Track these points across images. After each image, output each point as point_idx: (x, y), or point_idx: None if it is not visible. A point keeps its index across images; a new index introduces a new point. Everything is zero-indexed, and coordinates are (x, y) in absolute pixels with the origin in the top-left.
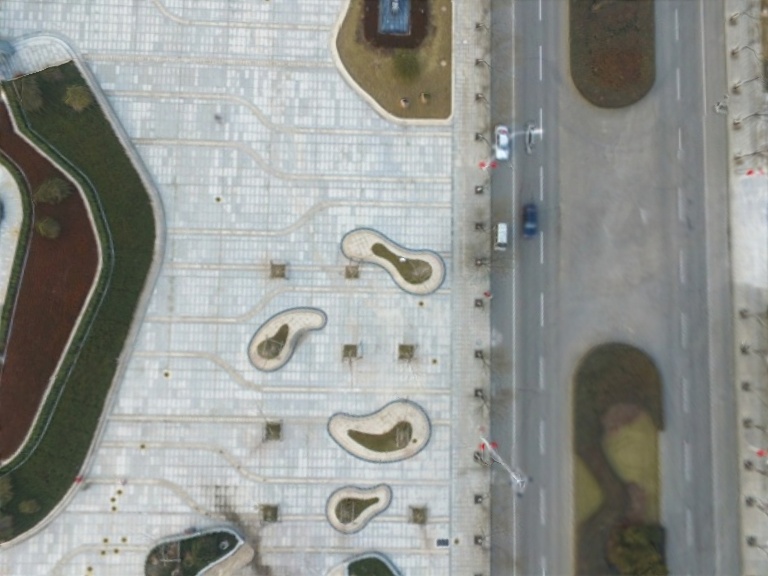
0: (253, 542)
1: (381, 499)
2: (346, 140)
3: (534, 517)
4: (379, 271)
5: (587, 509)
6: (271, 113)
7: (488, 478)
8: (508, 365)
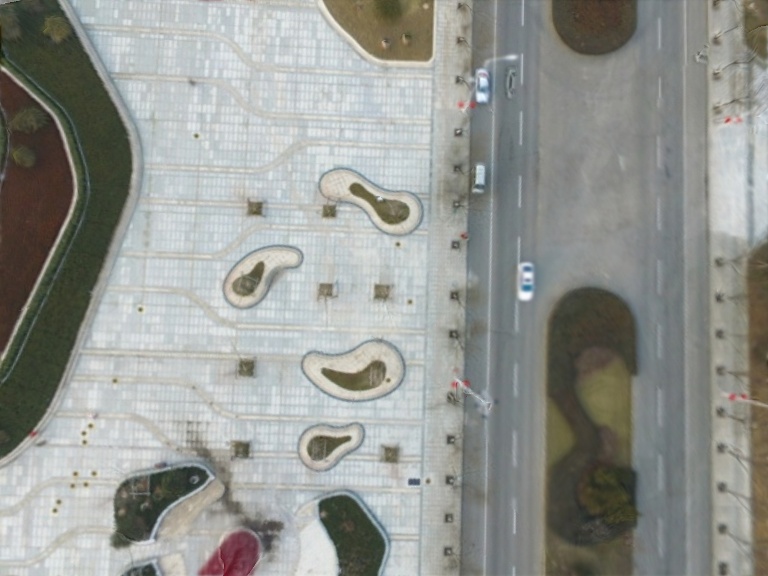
0: (224, 478)
1: (353, 437)
2: (326, 80)
3: (506, 459)
4: (357, 211)
5: (559, 451)
6: (252, 51)
7: (461, 418)
8: (484, 307)
